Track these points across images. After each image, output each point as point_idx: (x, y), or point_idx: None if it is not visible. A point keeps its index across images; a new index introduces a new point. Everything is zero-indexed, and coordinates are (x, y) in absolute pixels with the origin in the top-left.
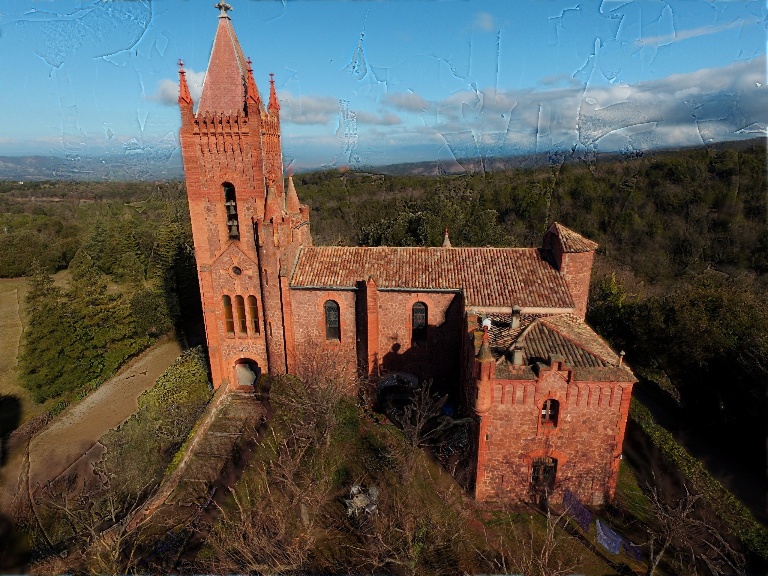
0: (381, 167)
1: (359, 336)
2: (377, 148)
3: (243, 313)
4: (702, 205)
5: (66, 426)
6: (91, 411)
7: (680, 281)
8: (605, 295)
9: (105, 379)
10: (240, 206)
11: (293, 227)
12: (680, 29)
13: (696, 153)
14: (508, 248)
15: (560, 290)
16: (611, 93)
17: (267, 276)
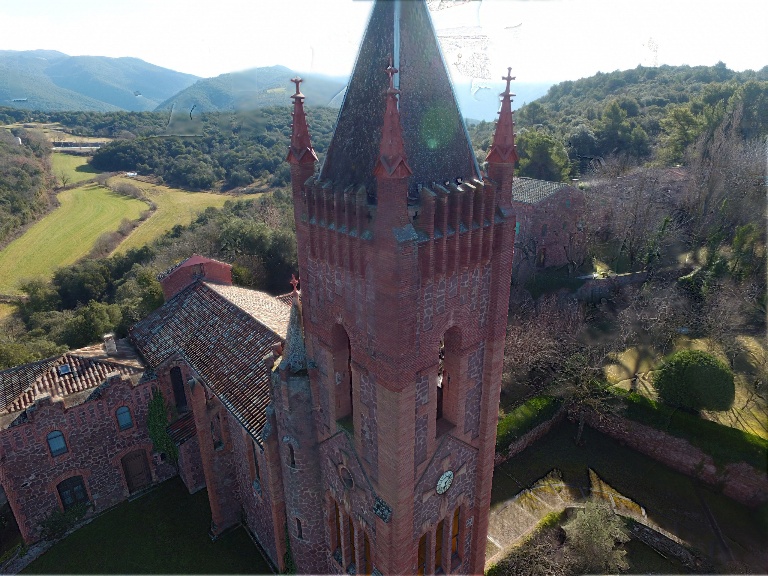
0: None
1: None
2: None
3: None
4: None
5: None
6: None
7: None
8: None
9: None
10: None
11: None
12: None
13: None
14: None
15: None
16: None
17: None
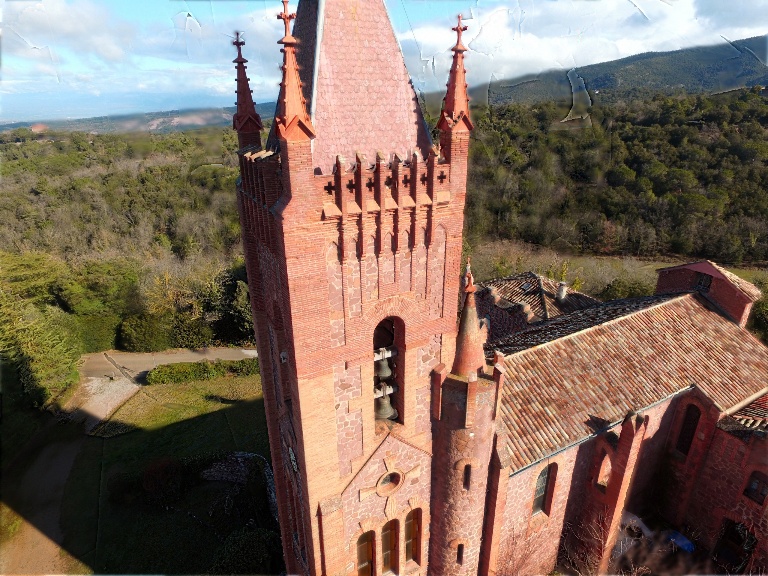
0: (214, 149)
1: (571, 494)
2: (209, 124)
3: (388, 542)
4: (583, 180)
5: None
6: None
7: (588, 257)
8: None
9: None
10: (411, 358)
11: None
12: (579, 6)
13: (582, 132)
14: (669, 302)
15: (762, 351)
16: (524, 70)
17: (470, 474)
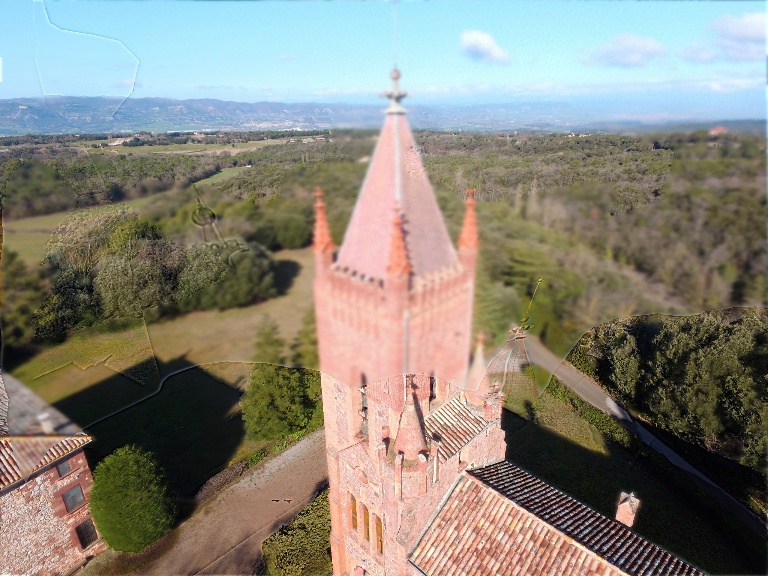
0: None
1: None
2: None
3: None
4: None
5: (250, 487)
6: (277, 475)
7: None
8: None
9: (309, 431)
10: (371, 405)
11: (442, 461)
12: None
13: None
14: None
15: None
16: None
17: (385, 521)
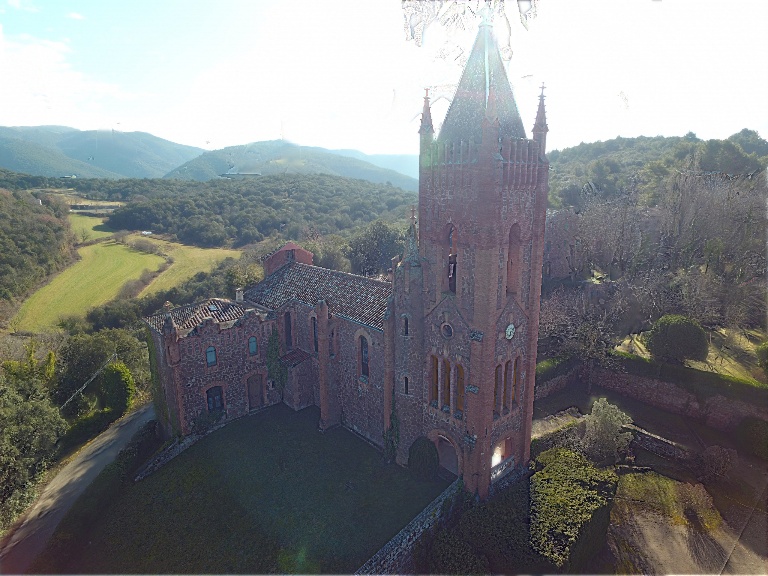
0: None
1: None
2: None
3: None
4: None
5: None
6: None
7: None
8: (43, 370)
9: None
10: None
11: None
12: None
13: None
14: None
15: None
16: None
17: None
